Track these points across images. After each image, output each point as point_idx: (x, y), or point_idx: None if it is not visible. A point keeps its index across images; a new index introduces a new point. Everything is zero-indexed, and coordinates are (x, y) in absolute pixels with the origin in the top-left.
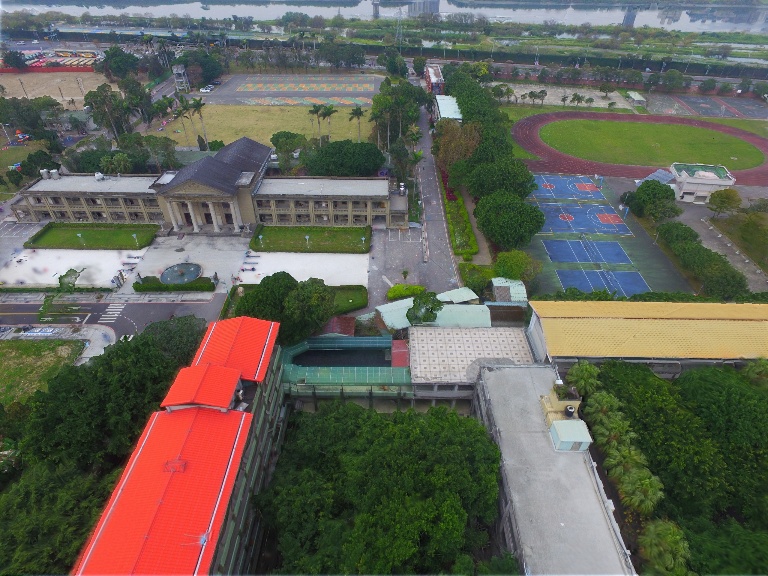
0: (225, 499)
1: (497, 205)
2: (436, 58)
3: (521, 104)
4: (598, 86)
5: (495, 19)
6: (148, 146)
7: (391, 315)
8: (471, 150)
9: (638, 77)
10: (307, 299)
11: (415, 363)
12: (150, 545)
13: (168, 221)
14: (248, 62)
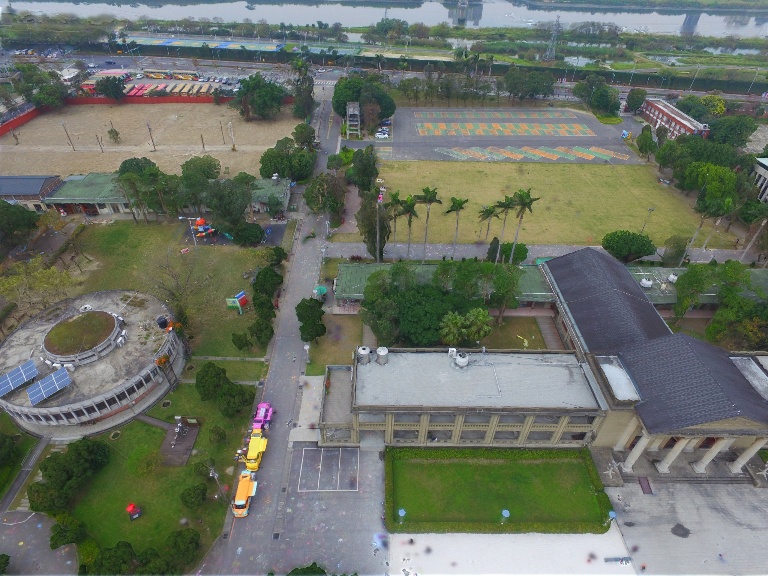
0: None
1: None
2: (620, 84)
3: None
4: None
5: (663, 33)
6: (475, 277)
7: None
8: None
9: None
10: None
11: None
12: None
13: (596, 444)
14: (412, 92)
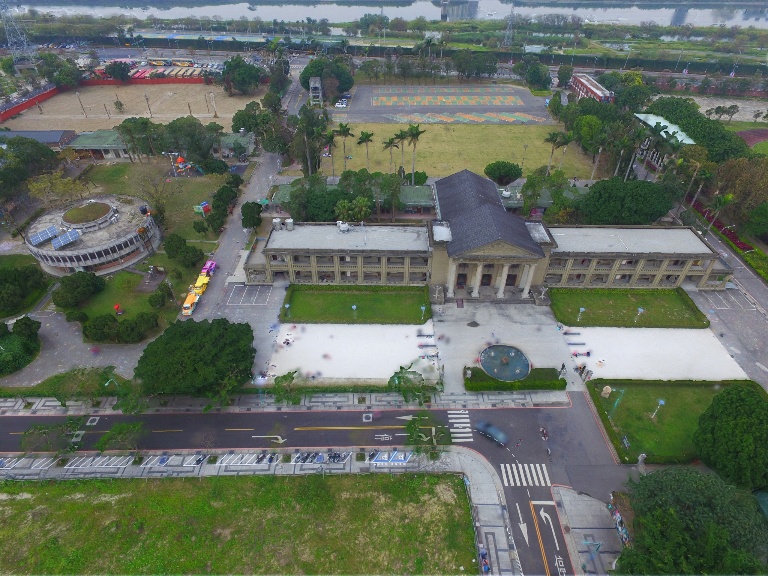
0: None
1: None
2: (562, 65)
3: None
4: (767, 98)
5: None
6: (370, 184)
7: None
8: None
9: None
10: None
11: None
12: None
13: (434, 282)
14: (372, 72)
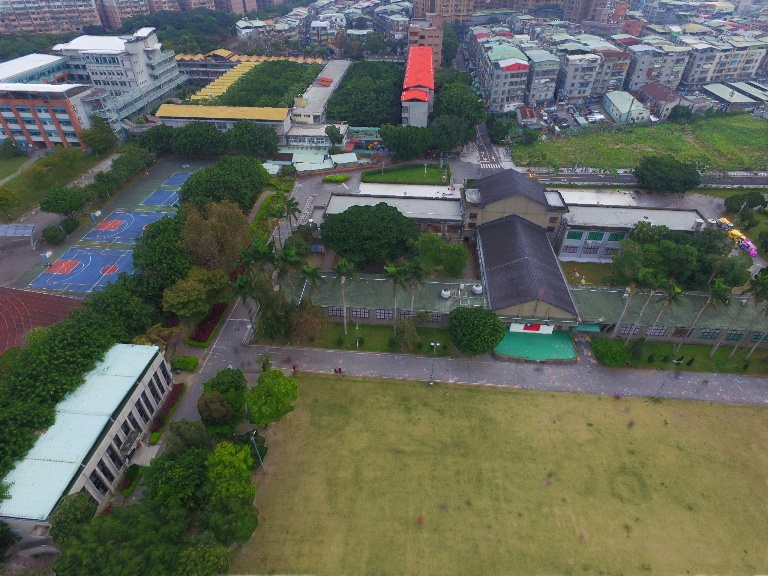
0: None
1: None
2: None
3: None
4: None
5: None
6: None
7: None
8: None
9: None
10: None
11: None
12: None
13: None
14: None
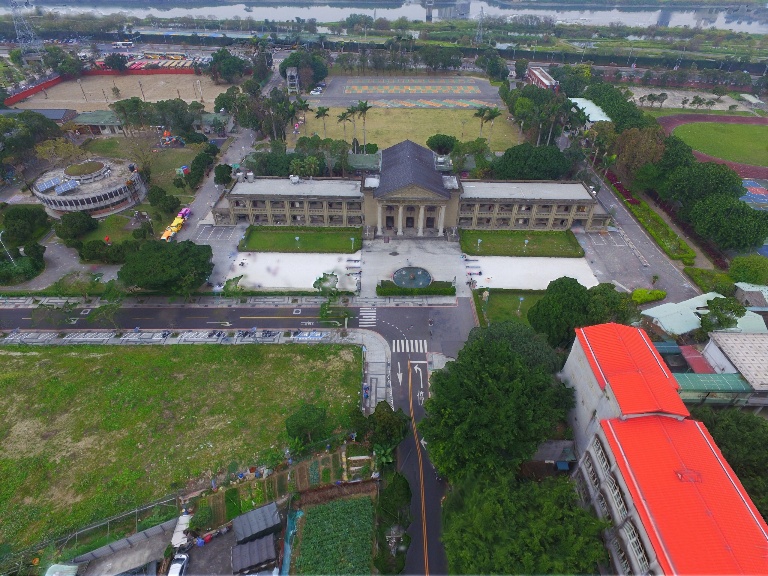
0: (755, 510)
1: (725, 209)
2: None
3: (638, 107)
4: (703, 88)
5: (574, 21)
6: (323, 149)
7: (667, 320)
8: (660, 154)
9: (748, 79)
10: (610, 304)
11: (743, 370)
12: (739, 557)
13: (367, 224)
14: (347, 64)
